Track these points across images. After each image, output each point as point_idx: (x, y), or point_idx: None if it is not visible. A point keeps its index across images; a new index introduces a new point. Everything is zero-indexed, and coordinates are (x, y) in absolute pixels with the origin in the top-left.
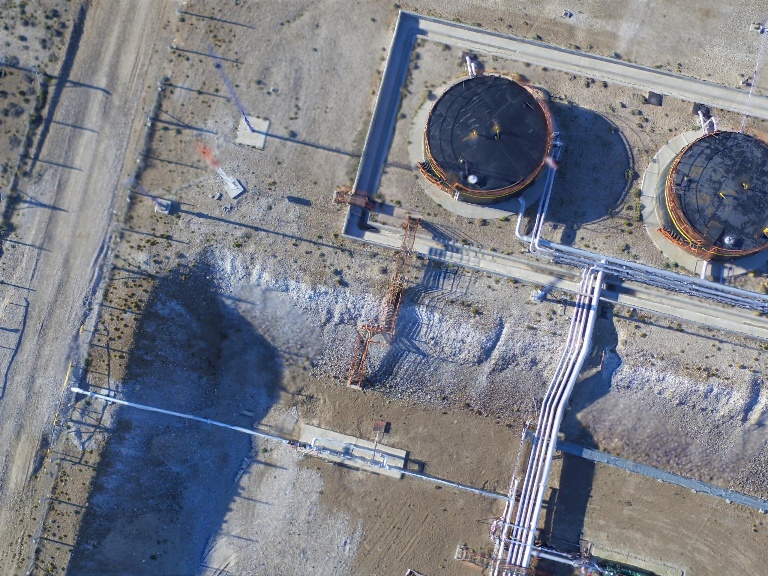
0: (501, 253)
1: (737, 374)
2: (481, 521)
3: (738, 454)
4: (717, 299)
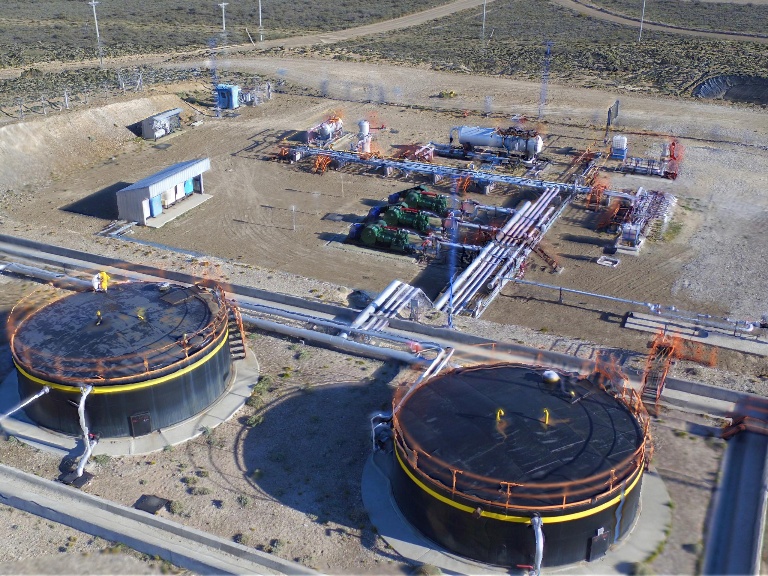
0: None
1: (214, 261)
2: None
3: None
4: None
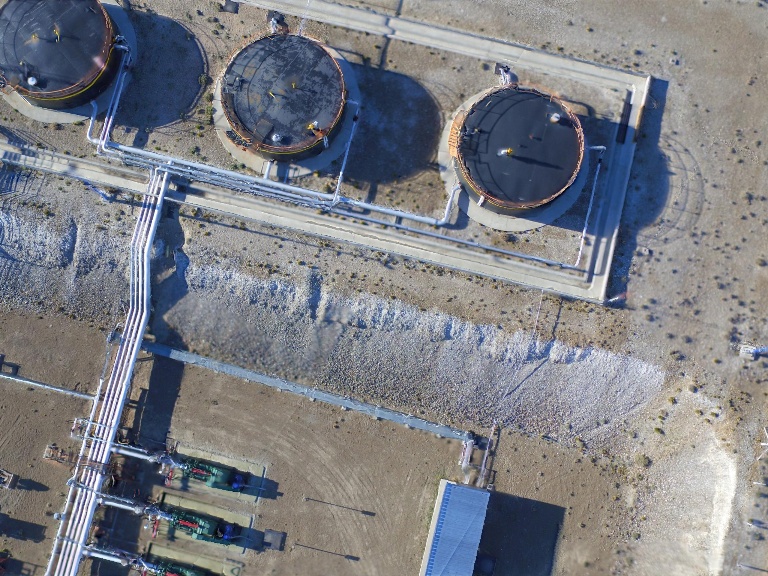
0: (74, 156)
1: (296, 270)
2: (71, 421)
3: (316, 352)
4: (278, 198)
